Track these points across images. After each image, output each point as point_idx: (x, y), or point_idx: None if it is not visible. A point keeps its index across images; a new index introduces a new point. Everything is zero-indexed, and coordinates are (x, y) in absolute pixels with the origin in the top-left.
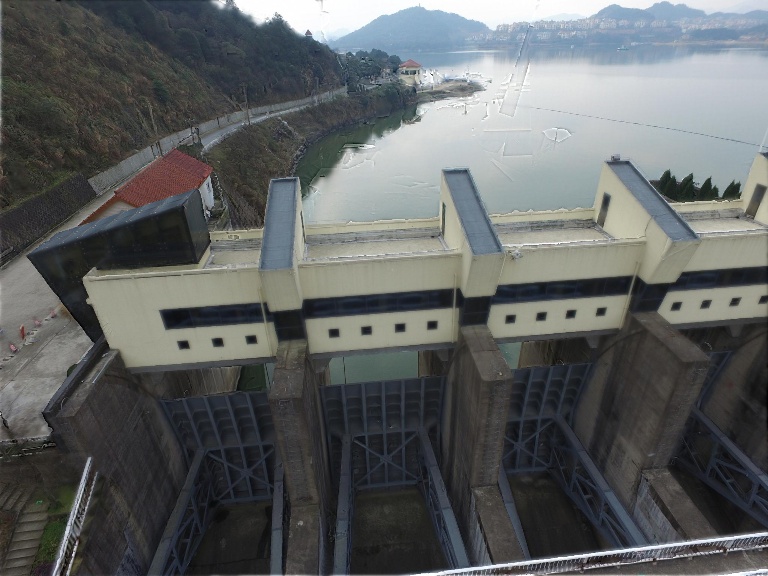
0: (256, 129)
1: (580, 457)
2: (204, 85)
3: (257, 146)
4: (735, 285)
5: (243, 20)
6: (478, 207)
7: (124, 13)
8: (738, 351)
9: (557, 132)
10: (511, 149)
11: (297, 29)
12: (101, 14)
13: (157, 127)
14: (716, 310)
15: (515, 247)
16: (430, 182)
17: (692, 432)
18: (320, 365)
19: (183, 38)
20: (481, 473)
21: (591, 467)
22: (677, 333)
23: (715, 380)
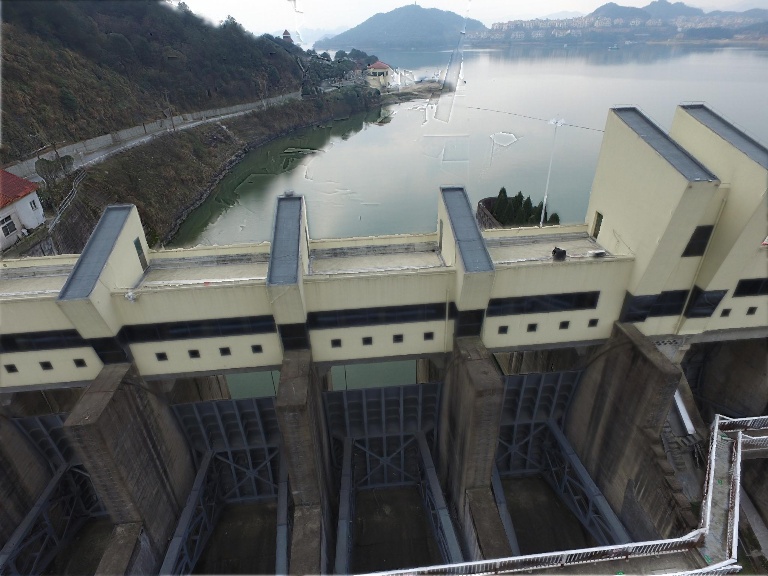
0: (182, 135)
1: (278, 488)
2: (137, 90)
3: (176, 153)
4: (391, 323)
5: (192, 23)
6: (111, 247)
7: (41, 20)
8: (444, 383)
9: (503, 136)
10: (450, 154)
11: (252, 32)
12: (13, 21)
13: (59, 136)
14: (381, 346)
15: (133, 289)
16: (351, 189)
17: (433, 459)
18: (4, 398)
19: (115, 43)
20: (117, 511)
21: (282, 499)
22: (304, 373)
23: (440, 409)
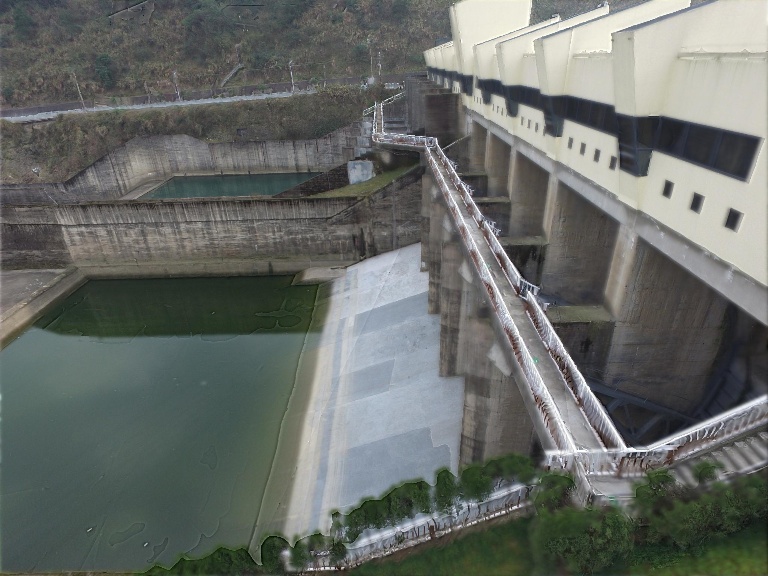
0: None
1: None
2: None
3: None
4: None
5: None
6: None
7: None
8: None
9: None
10: None
11: None
12: None
13: None
14: None
15: None
16: None
17: None
18: None
19: None
20: None
21: None
22: None
23: None
